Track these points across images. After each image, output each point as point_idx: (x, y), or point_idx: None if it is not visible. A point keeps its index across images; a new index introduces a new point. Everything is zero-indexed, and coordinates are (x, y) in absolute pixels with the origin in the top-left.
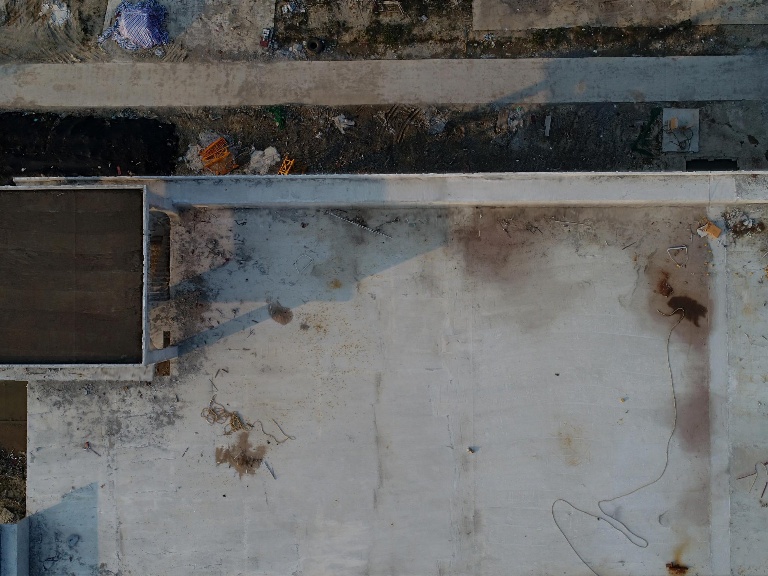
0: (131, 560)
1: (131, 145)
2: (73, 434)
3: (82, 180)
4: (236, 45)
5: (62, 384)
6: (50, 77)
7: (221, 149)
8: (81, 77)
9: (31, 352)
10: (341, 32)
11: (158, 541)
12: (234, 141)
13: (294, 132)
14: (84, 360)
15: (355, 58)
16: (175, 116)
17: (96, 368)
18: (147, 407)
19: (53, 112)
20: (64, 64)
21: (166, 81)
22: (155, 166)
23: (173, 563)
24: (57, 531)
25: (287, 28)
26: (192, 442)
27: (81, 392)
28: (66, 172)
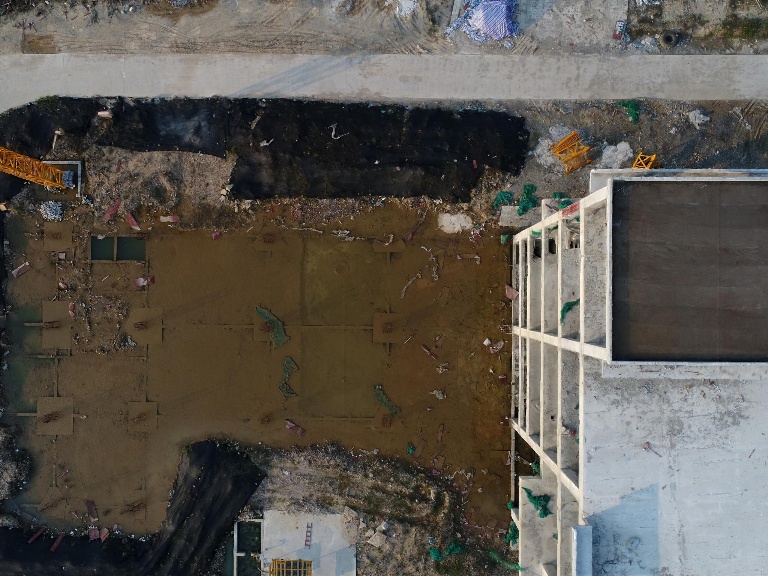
0: (694, 564)
1: (487, 138)
2: (632, 434)
3: (661, 172)
4: (588, 38)
5: (621, 382)
6: (396, 68)
7: (574, 143)
8: (428, 68)
9: (672, 349)
10: (696, 26)
11: (723, 545)
12: (585, 135)
13: (647, 127)
14: (728, 358)
15: (710, 52)
16: (525, 109)
17: (714, 366)
18: (710, 407)
19: (399, 104)
20: (411, 55)
21: (515, 73)
22: (508, 160)
23: (739, 568)
24: (615, 533)
25: (641, 21)
26: (758, 443)
27: (641, 391)
28: (422, 165)
